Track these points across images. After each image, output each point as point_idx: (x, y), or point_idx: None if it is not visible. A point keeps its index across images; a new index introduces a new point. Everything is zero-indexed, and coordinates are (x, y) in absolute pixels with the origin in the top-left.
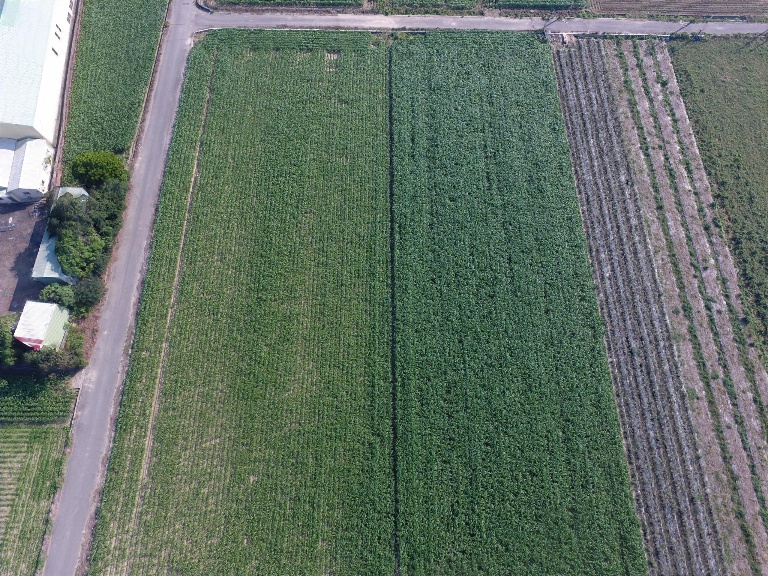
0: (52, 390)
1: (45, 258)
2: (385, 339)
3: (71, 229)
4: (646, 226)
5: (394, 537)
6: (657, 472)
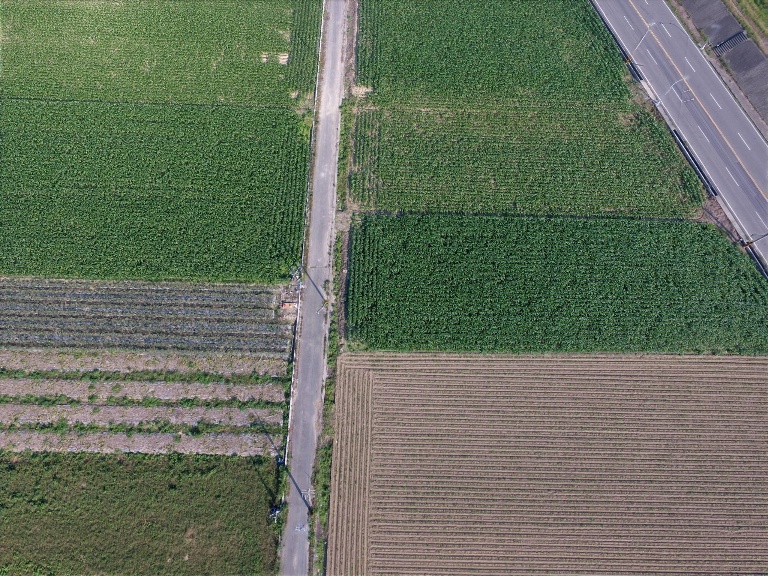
0: None
1: None
2: None
3: None
4: None
5: None
6: None
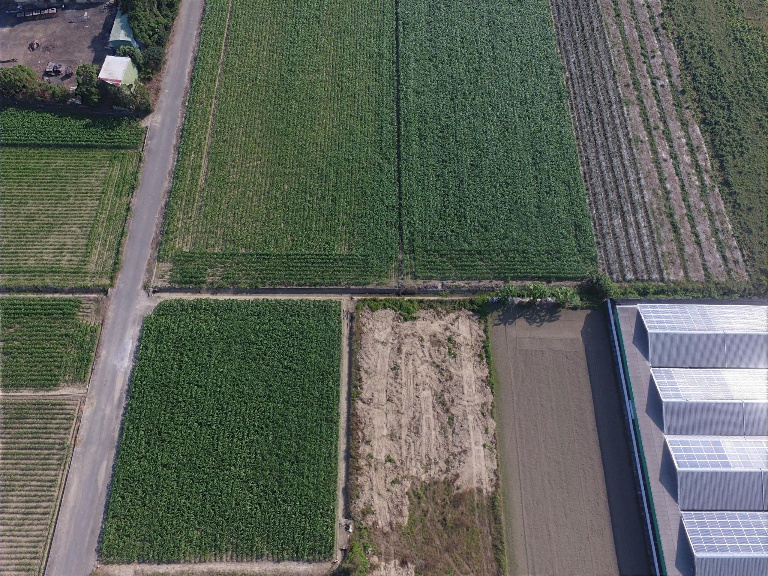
0: (126, 127)
1: (119, 28)
2: (391, 98)
3: (141, 2)
4: (606, 28)
5: (398, 222)
6: (606, 187)
